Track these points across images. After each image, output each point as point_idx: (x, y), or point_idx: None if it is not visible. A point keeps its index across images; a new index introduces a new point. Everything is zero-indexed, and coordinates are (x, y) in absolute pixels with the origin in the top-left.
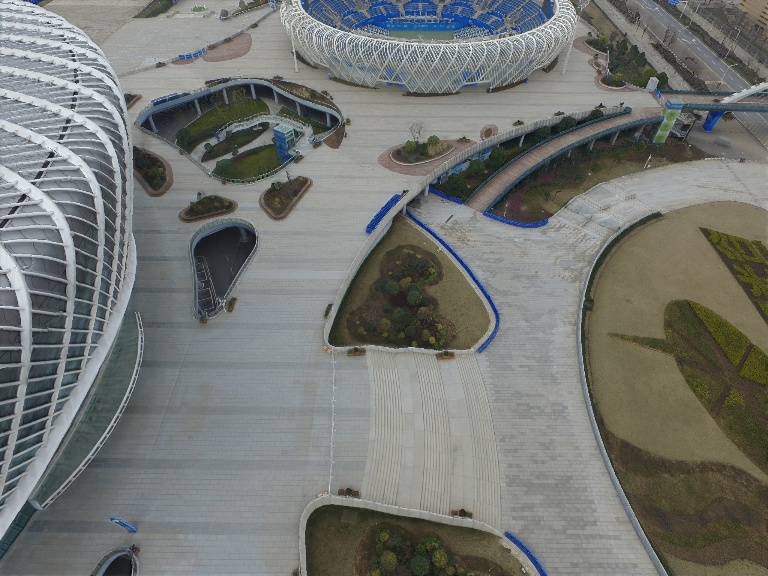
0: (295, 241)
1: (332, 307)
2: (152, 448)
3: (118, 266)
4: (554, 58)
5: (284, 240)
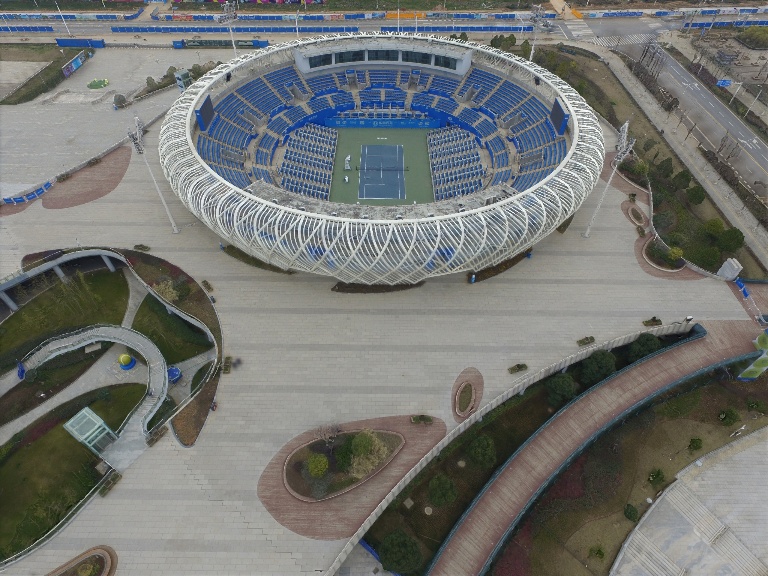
0: None
1: None
2: None
3: None
4: None
5: None
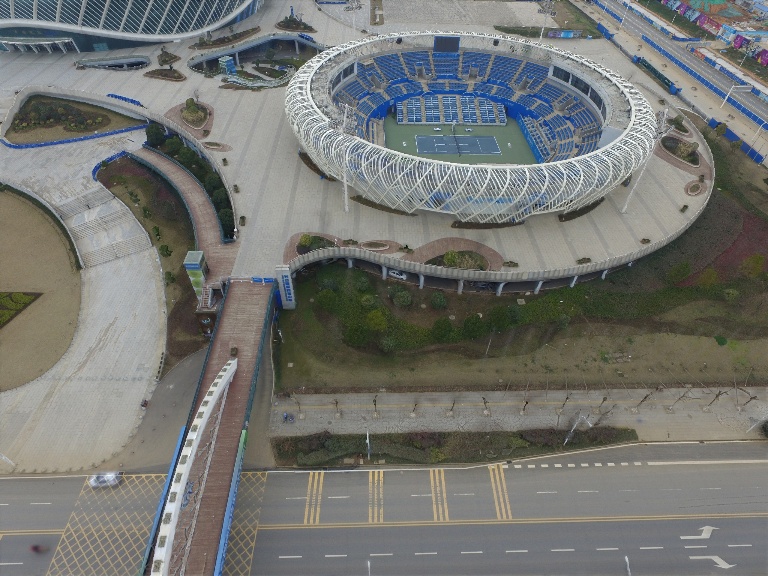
0: None
1: (53, 87)
2: None
3: (46, 5)
4: (377, 198)
5: (123, 77)
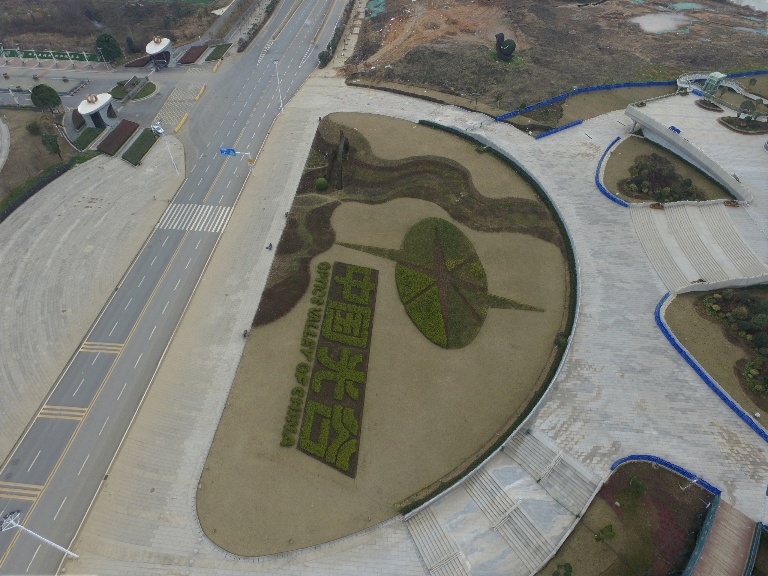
0: None
1: None
2: None
3: None
4: None
5: None
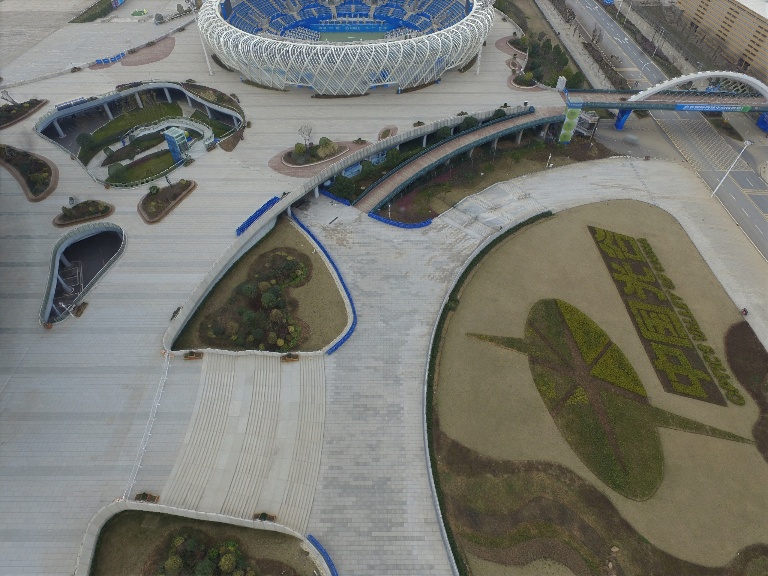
0: (163, 245)
1: (180, 311)
2: None
3: None
4: (470, 58)
5: (152, 244)
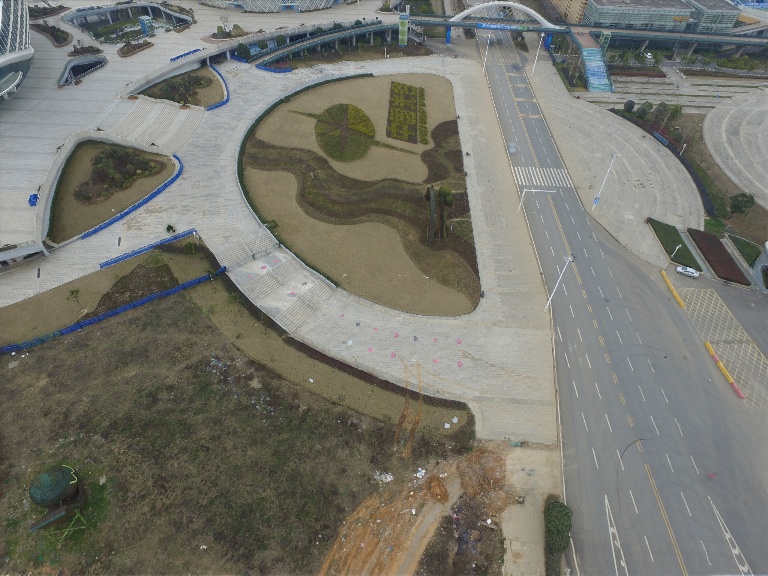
0: (128, 65)
1: (130, 84)
2: (16, 119)
3: (4, 31)
4: None
5: (122, 64)
